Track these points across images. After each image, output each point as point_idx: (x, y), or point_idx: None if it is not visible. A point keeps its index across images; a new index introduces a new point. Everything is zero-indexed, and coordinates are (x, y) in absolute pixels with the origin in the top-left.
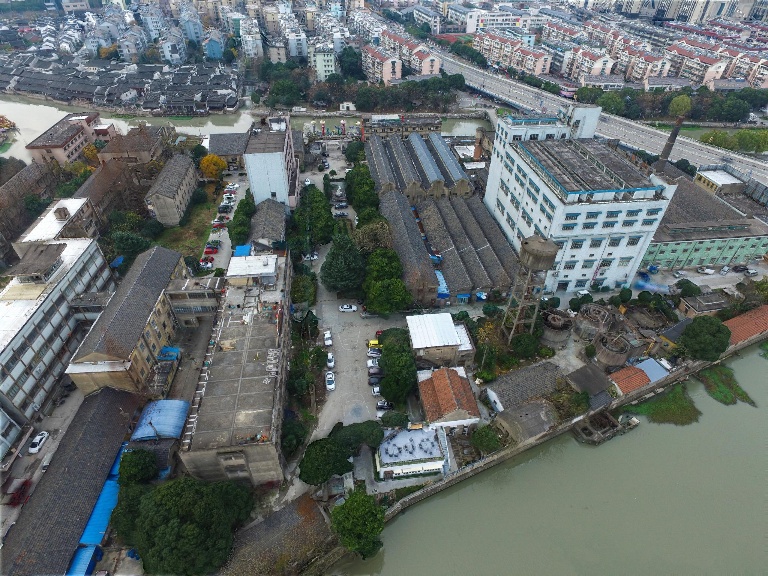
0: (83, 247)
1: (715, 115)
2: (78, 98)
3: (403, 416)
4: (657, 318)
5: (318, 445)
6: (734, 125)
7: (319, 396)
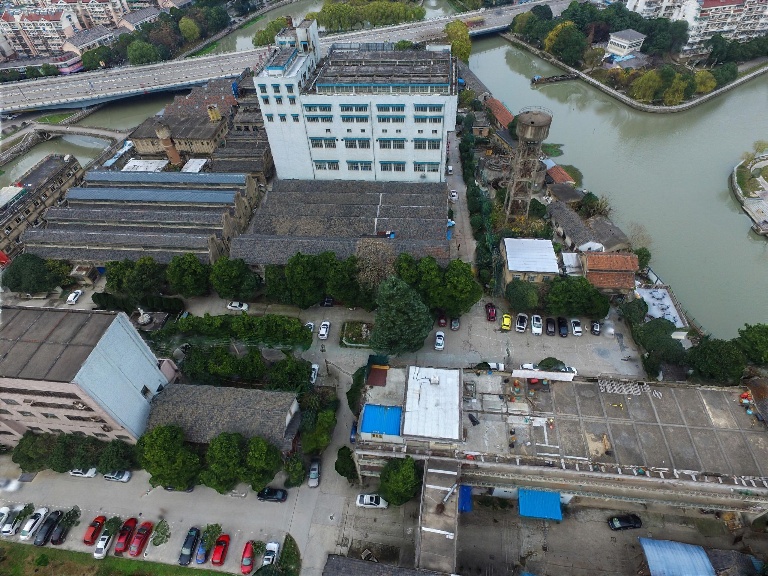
0: None
1: (215, 27)
2: None
3: (640, 300)
4: (481, 149)
5: (732, 350)
6: (229, 30)
7: None
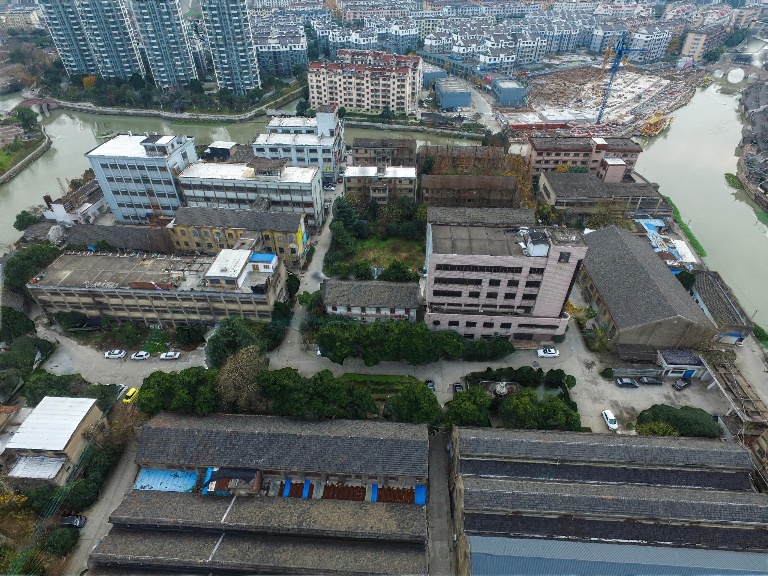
0: (301, 181)
1: None
2: (754, 145)
3: None
4: None
5: None
6: None
7: (107, 347)
